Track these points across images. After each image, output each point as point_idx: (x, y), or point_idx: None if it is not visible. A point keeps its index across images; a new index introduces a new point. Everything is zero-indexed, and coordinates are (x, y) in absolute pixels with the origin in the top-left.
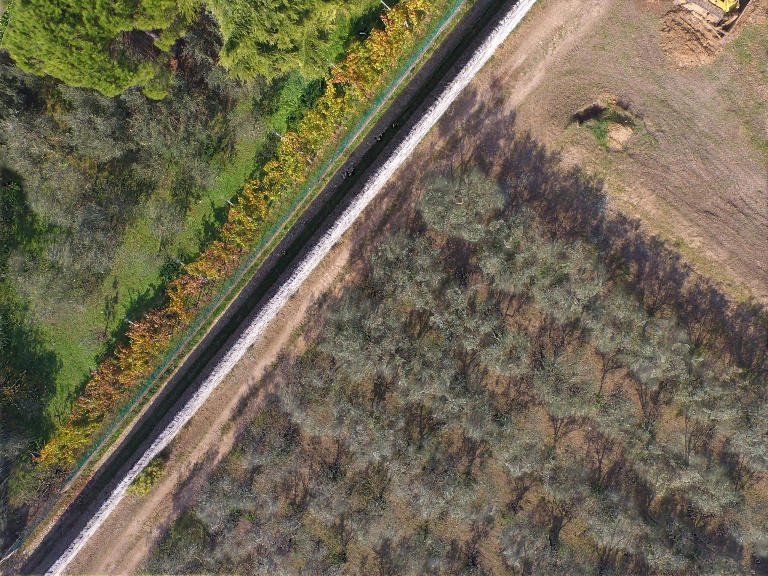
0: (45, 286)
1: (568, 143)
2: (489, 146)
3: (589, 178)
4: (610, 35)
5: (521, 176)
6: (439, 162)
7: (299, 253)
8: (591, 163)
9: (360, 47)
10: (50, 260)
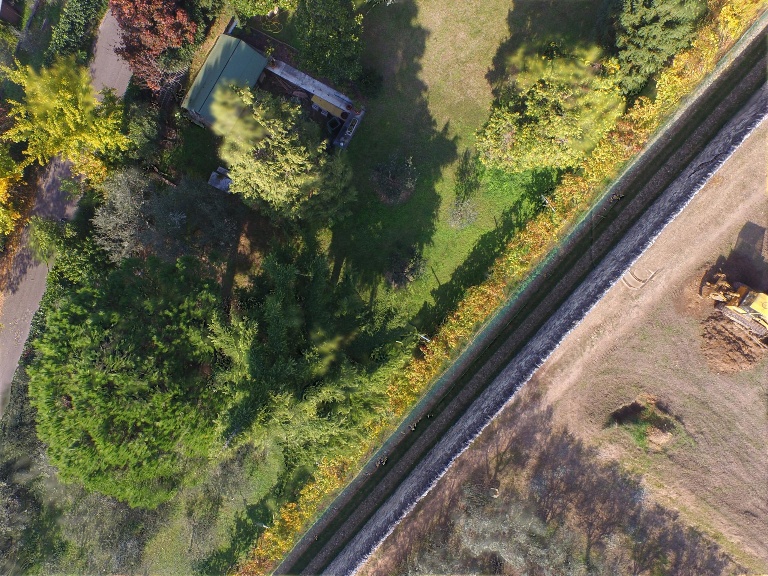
0: (74, 574)
1: (606, 440)
2: (525, 439)
3: (627, 472)
4: (649, 337)
5: (557, 468)
6: (474, 452)
7: (331, 538)
8: (629, 460)
9: (399, 378)
10: (79, 548)
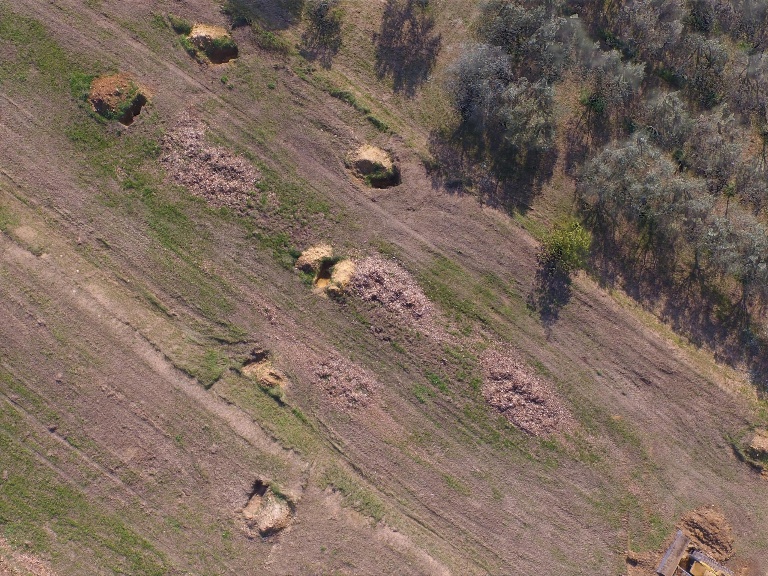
0: None
1: None
2: None
3: None
4: None
5: None
6: None
7: None
8: None
9: None
10: None
